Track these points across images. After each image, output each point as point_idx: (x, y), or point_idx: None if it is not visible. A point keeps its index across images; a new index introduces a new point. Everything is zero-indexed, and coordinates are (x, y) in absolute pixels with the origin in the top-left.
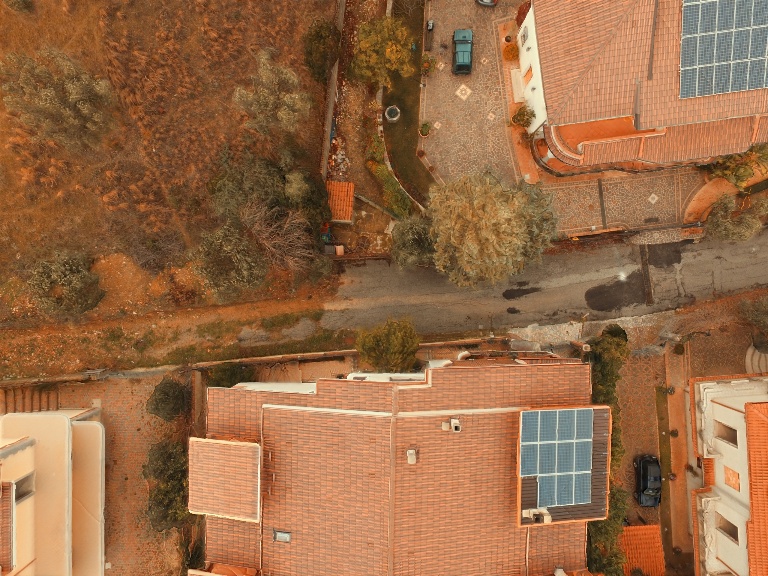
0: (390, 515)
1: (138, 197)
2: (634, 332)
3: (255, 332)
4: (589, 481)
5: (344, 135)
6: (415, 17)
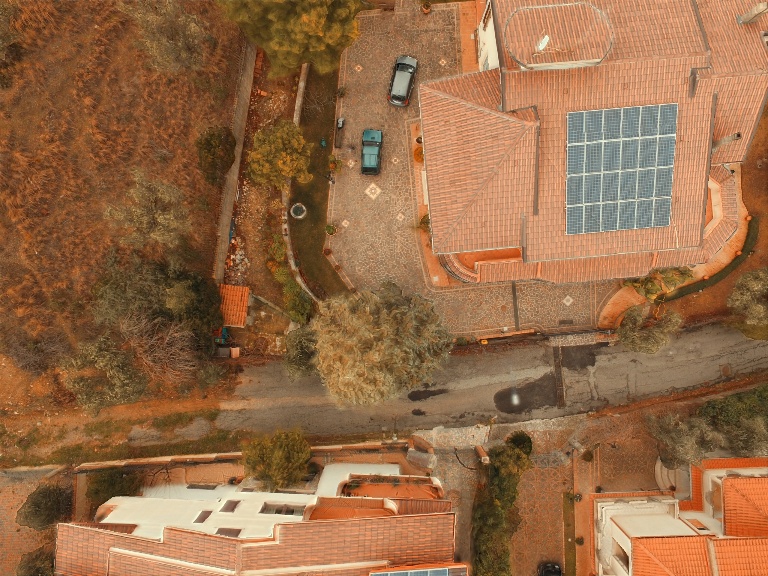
0: None
1: (16, 301)
2: (543, 436)
3: (146, 432)
4: None
5: (244, 235)
6: (326, 113)
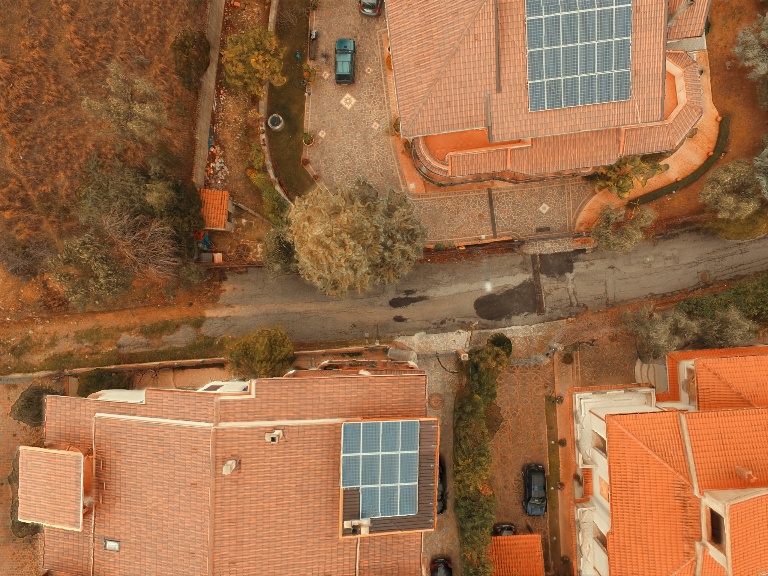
0: (210, 525)
1: (3, 204)
2: (524, 341)
3: (134, 339)
4: (415, 492)
5: (223, 143)
6: (300, 26)
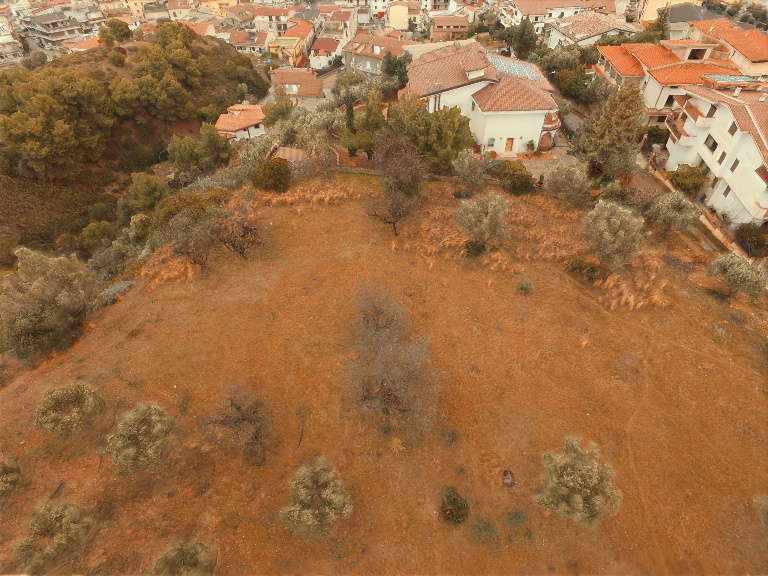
0: None
1: None
2: None
3: (704, 244)
4: None
5: None
6: None
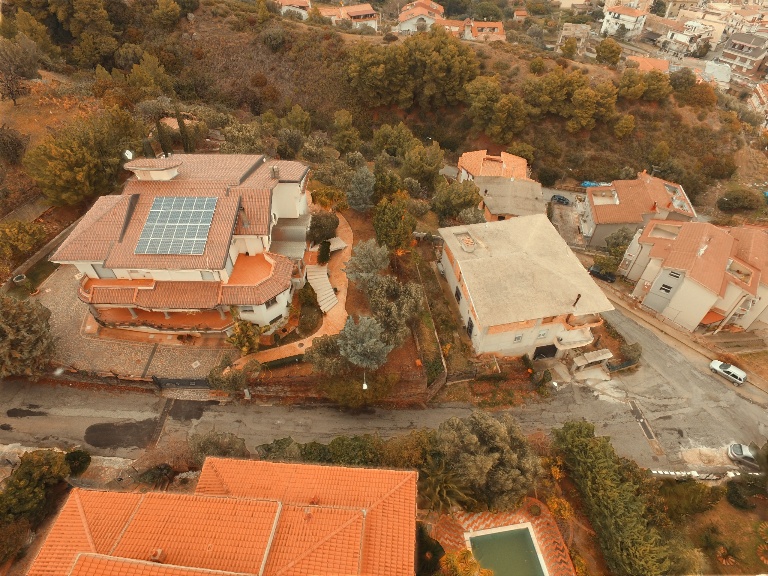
0: None
1: None
2: (116, 473)
3: None
4: None
5: None
6: None
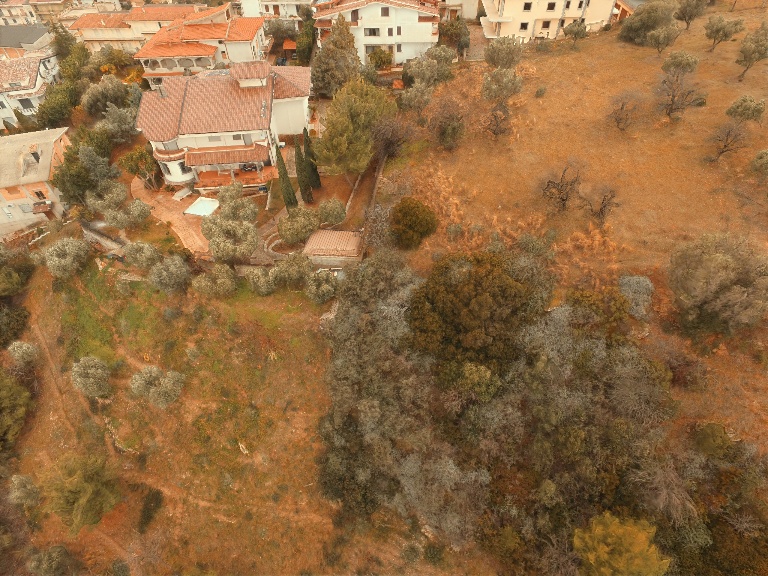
0: None
1: None
2: None
3: None
4: None
5: None
6: None
